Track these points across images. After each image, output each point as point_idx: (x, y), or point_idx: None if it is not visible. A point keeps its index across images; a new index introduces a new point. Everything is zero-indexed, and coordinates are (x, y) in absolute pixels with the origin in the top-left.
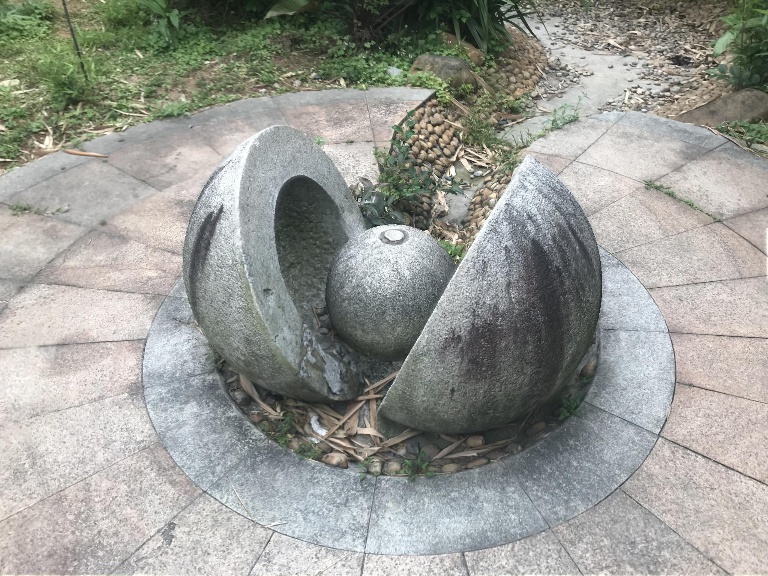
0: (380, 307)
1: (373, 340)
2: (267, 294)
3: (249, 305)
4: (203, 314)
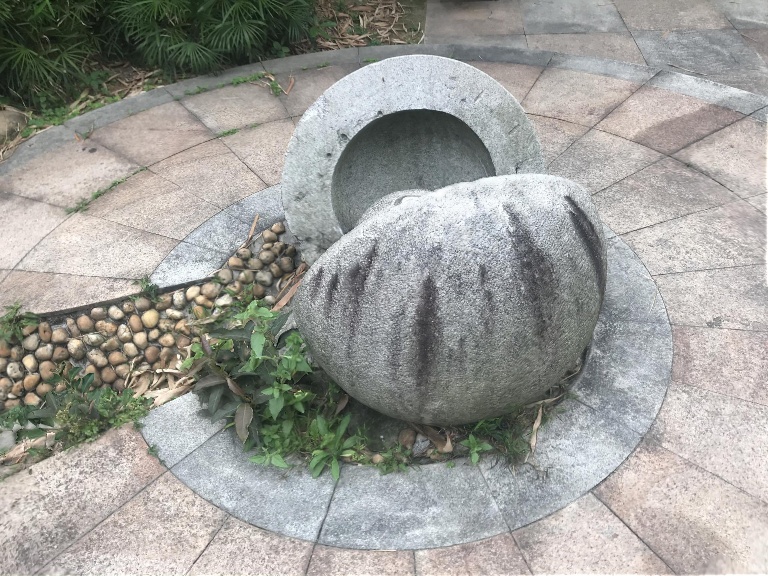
0: None
1: None
2: None
3: None
4: None
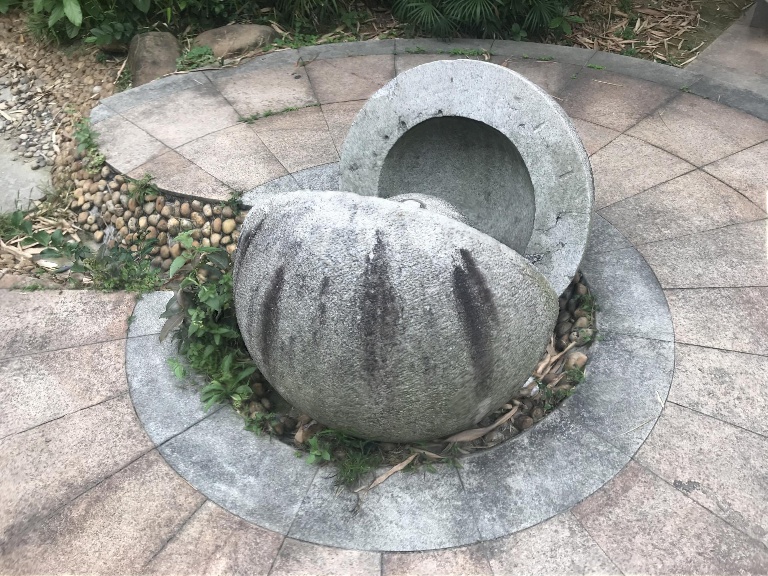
0: None
1: None
2: None
3: None
4: (506, 370)
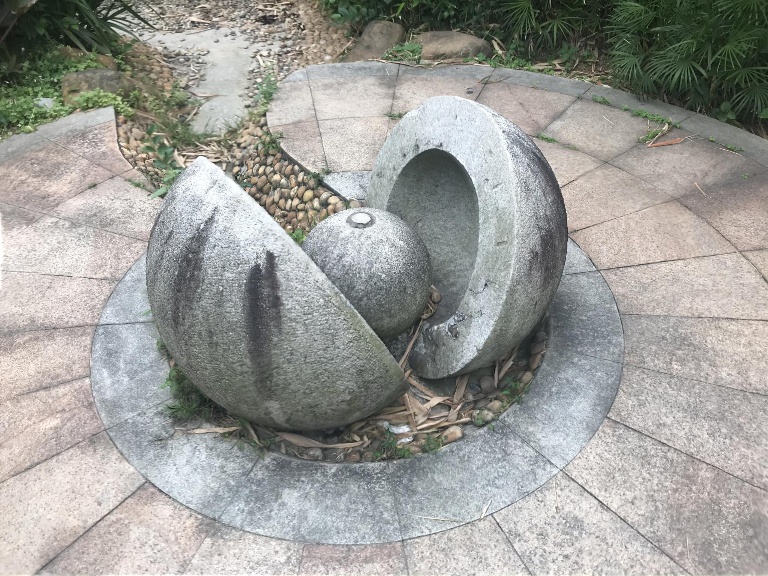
0: (400, 285)
1: (400, 320)
2: None
3: (361, 333)
4: (288, 381)
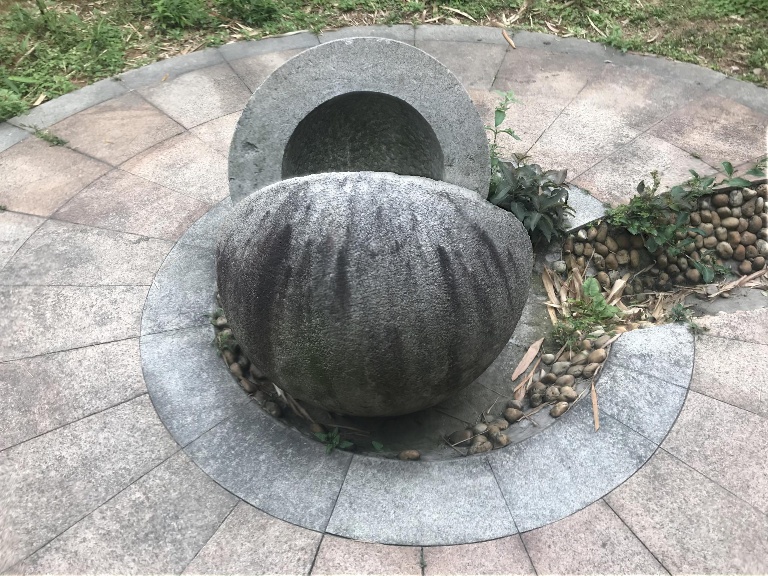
0: None
1: None
2: (252, 148)
3: None
4: None
